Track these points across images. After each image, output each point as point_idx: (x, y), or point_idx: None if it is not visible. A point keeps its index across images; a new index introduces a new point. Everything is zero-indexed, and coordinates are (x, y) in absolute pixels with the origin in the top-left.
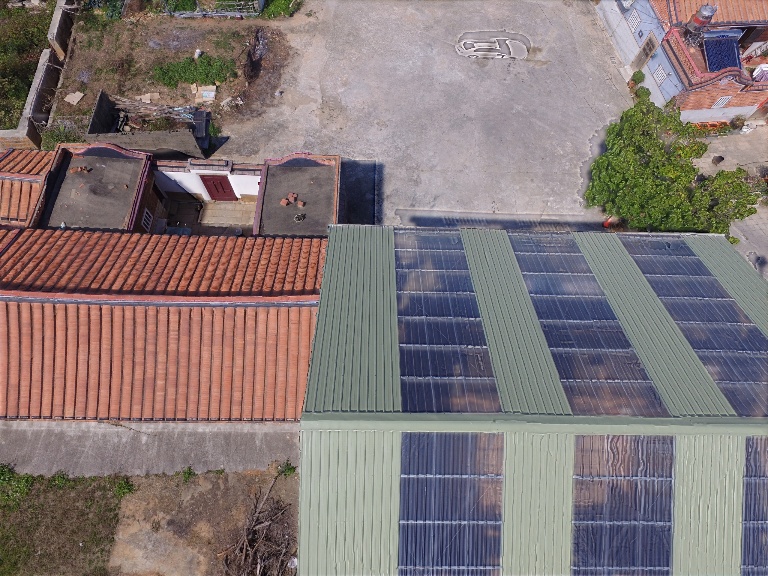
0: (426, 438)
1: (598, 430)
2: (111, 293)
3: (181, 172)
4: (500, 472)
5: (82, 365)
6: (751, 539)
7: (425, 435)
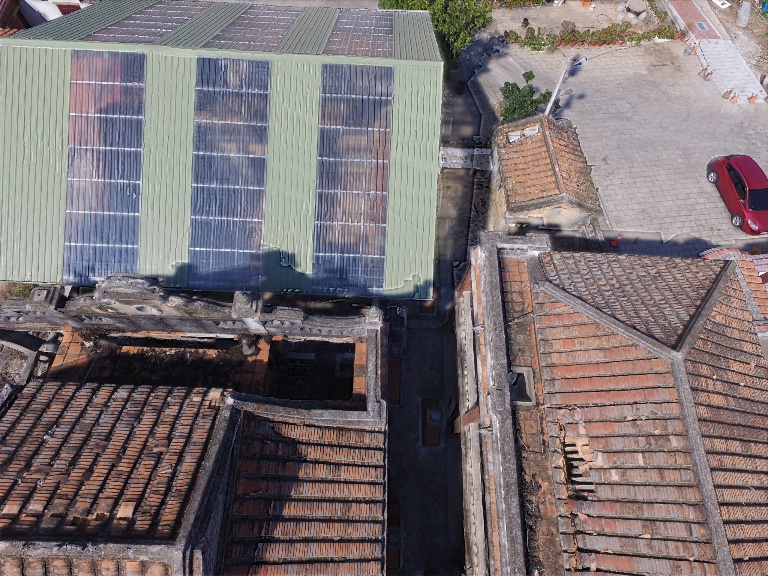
0: (89, 55)
1: (212, 54)
2: None
3: (40, 0)
4: (141, 81)
5: None
6: (325, 138)
7: (88, 53)
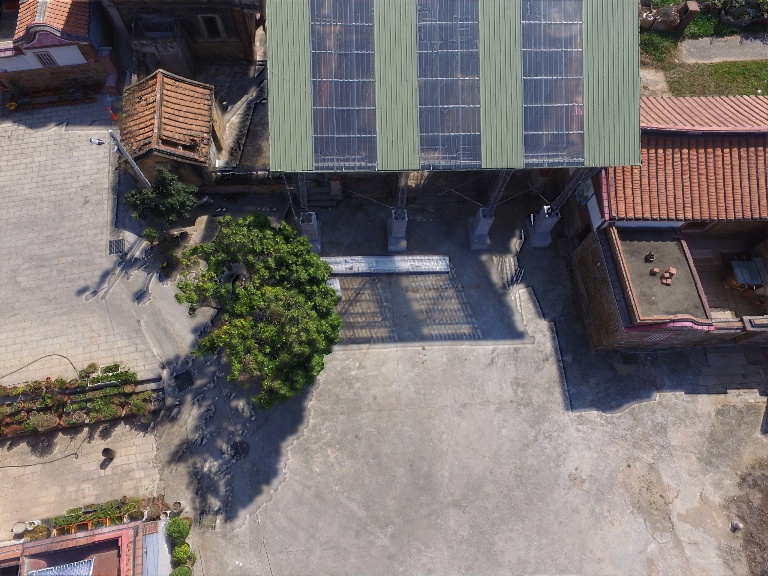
0: None
1: None
2: None
3: None
4: None
5: None
6: None
7: None
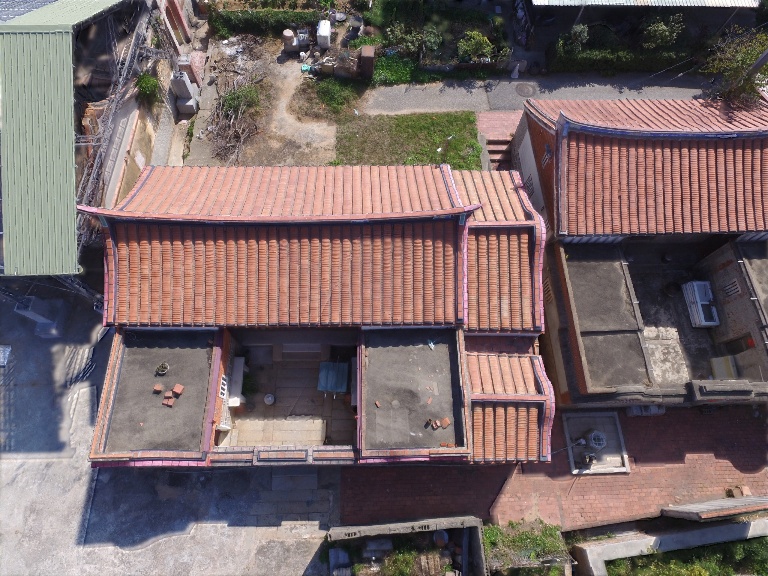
0: None
1: None
2: (327, 233)
3: (323, 446)
4: None
5: (348, 190)
6: None
7: None
